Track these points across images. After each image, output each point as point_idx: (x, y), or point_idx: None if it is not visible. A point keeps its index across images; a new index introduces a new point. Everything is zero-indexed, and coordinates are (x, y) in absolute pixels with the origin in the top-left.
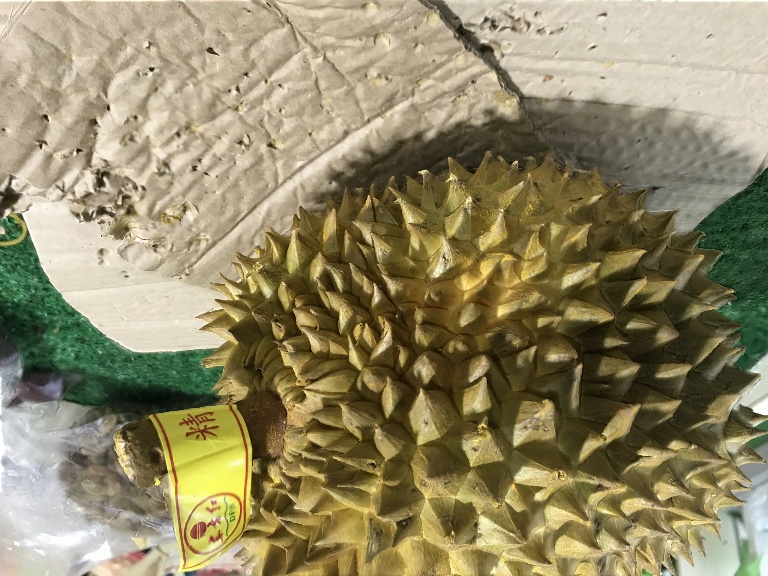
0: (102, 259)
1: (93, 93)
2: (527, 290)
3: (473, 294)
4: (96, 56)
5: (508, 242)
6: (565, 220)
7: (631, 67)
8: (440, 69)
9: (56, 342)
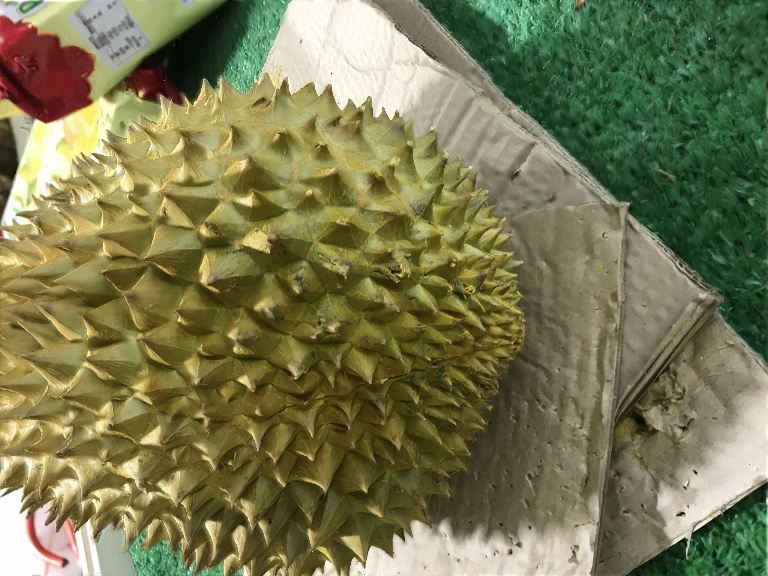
0: None
1: None
2: None
3: None
4: None
5: None
6: None
7: None
8: None
9: None
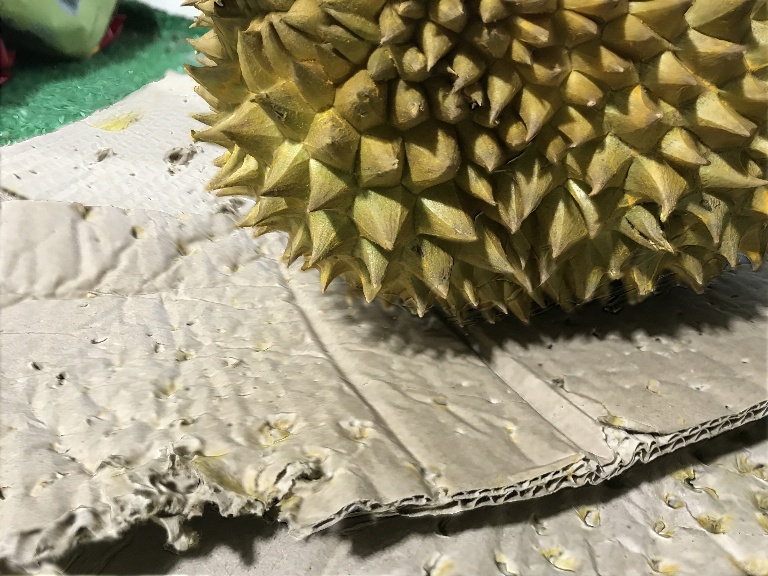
0: None
1: (22, 427)
2: None
3: None
4: None
5: None
6: None
7: None
8: None
9: None
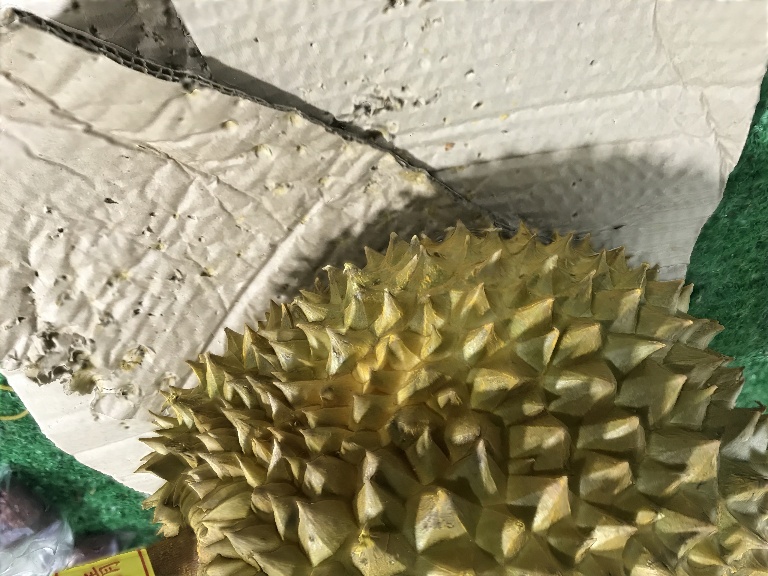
0: (97, 415)
1: (15, 264)
2: (419, 369)
3: (368, 385)
4: (4, 231)
5: (405, 321)
6: (466, 285)
7: (529, 114)
8: (334, 164)
9: (99, 503)
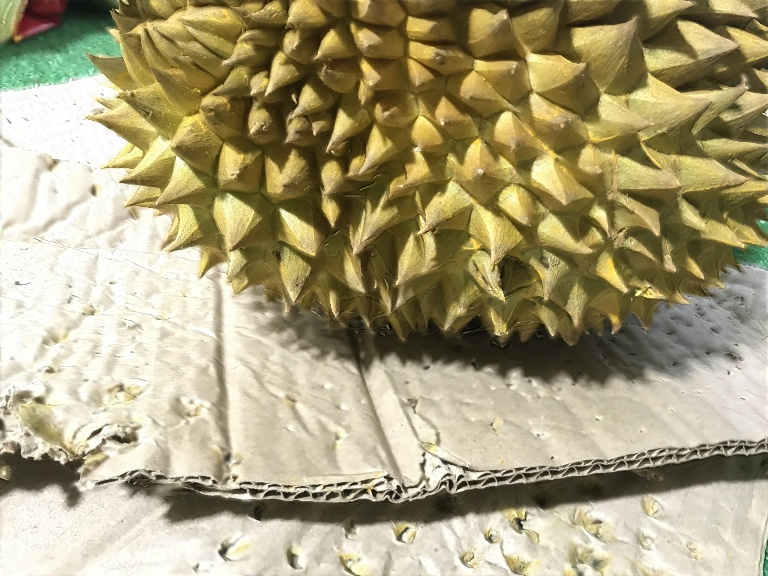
0: None
1: None
2: None
3: None
4: None
5: None
6: None
7: None
8: None
9: None
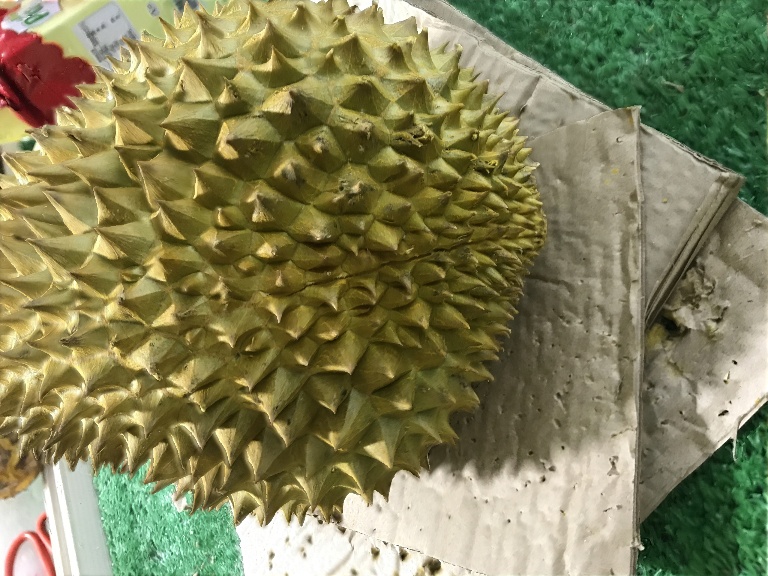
0: (272, 564)
1: None
2: None
3: None
4: None
5: None
6: None
7: None
8: None
9: None
